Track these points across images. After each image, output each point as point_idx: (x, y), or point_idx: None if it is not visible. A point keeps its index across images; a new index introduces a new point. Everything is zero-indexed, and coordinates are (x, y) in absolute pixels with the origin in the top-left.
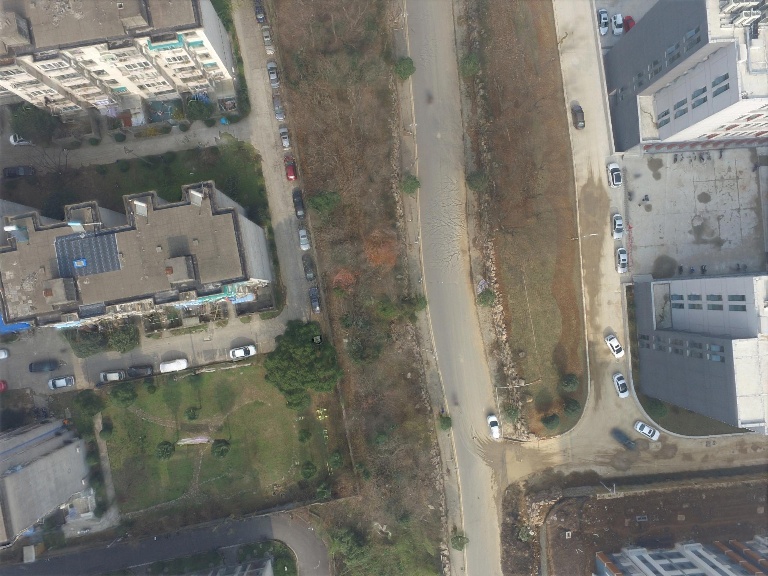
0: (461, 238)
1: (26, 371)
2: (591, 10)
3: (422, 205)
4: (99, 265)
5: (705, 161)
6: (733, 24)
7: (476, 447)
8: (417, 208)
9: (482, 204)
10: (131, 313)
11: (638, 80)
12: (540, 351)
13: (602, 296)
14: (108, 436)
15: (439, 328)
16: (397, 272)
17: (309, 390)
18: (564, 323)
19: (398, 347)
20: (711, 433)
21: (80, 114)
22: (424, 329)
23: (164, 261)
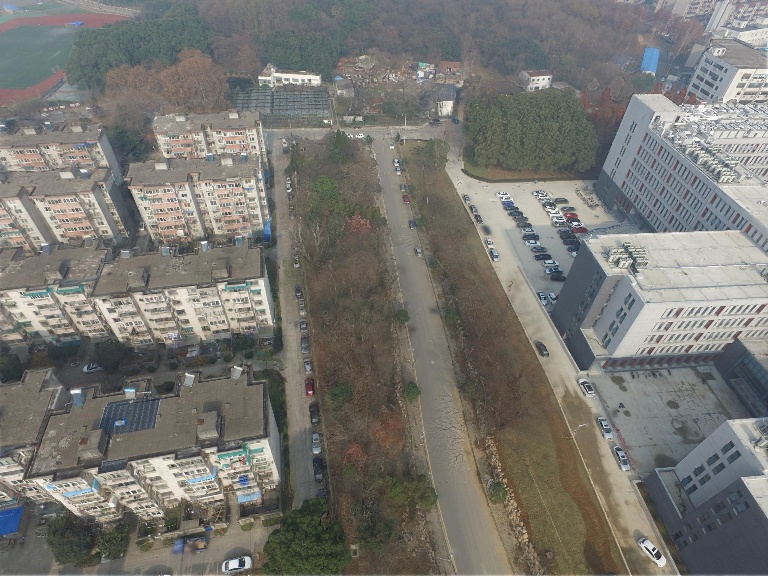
0: (463, 440)
1: None
2: (531, 291)
3: (424, 413)
4: (136, 425)
5: (659, 377)
6: (618, 267)
7: None
8: (420, 415)
9: (477, 409)
10: (139, 494)
11: (577, 318)
12: (568, 550)
13: (616, 495)
14: None
15: (454, 532)
16: (405, 468)
17: None
18: (585, 519)
19: (411, 550)
20: None
21: (150, 348)
22: (438, 533)
23: (198, 415)
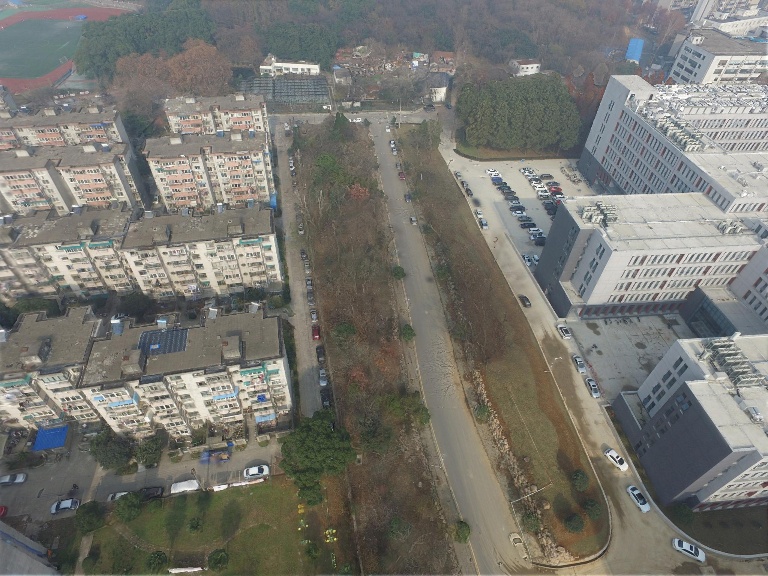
0: (453, 375)
1: (34, 497)
2: (517, 254)
3: (419, 353)
4: (169, 348)
5: (629, 323)
6: (591, 222)
7: (504, 575)
8: (415, 355)
9: (466, 349)
10: (171, 409)
11: (556, 272)
12: (543, 456)
13: (587, 417)
14: (90, 567)
15: (445, 446)
16: (402, 395)
17: (318, 511)
18: (559, 433)
19: (407, 457)
20: (761, 551)
21: (171, 300)
22: (431, 447)
23: (223, 338)
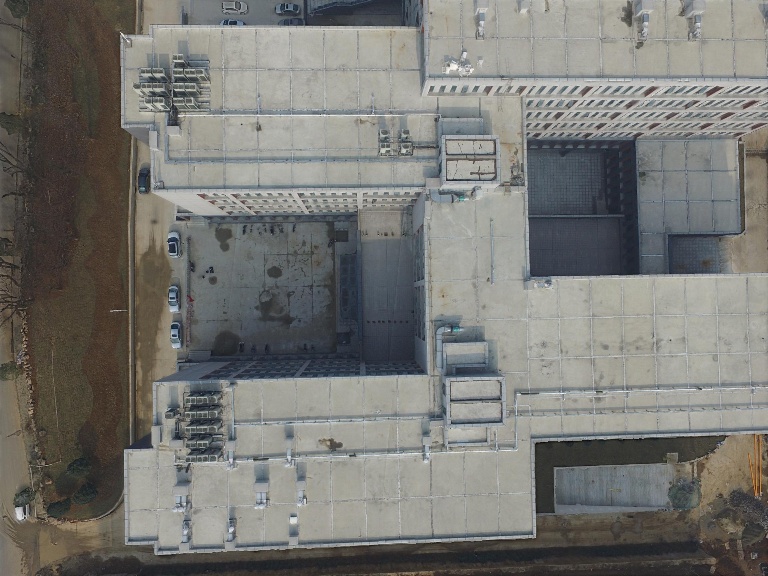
0: (4, 303)
1: None
2: None
3: None
4: None
5: (277, 234)
6: (150, 109)
7: (6, 527)
8: None
9: None
10: None
11: None
12: (63, 430)
13: (156, 371)
14: None
15: None
16: None
17: None
18: (96, 401)
19: None
20: None
21: None
22: None
23: None
